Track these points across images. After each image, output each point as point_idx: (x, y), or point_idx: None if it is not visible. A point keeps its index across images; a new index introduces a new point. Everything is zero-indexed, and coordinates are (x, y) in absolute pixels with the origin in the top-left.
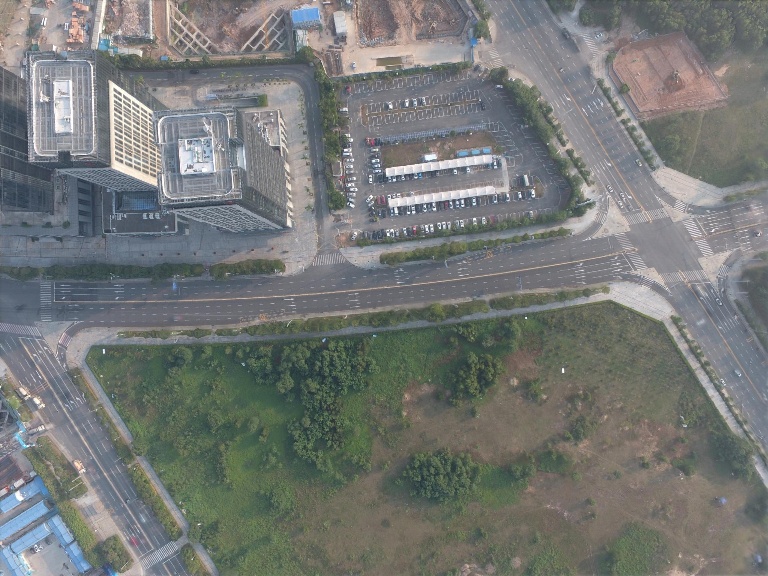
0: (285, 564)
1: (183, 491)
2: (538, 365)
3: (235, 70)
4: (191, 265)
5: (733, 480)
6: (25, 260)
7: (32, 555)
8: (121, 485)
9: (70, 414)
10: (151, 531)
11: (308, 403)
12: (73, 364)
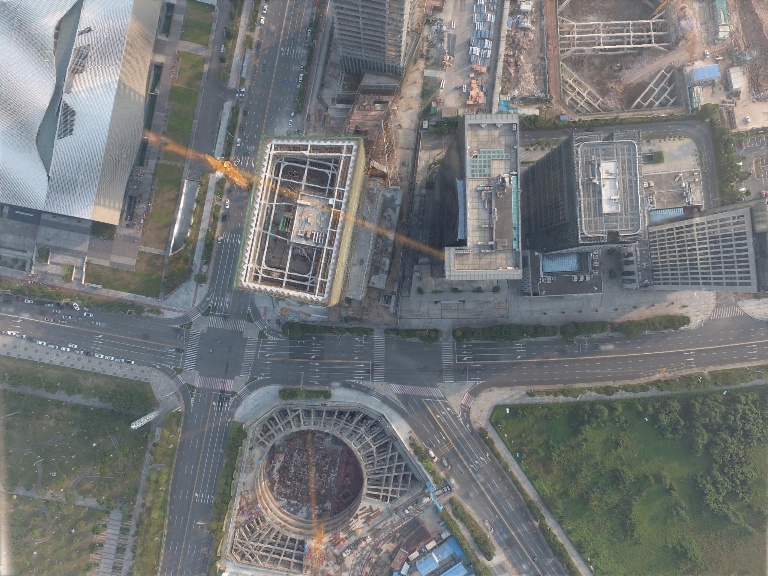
0: None
1: (590, 547)
2: None
3: (630, 127)
4: (600, 323)
5: None
6: (426, 322)
7: None
8: (528, 543)
9: (476, 474)
10: None
11: (718, 456)
12: (477, 424)
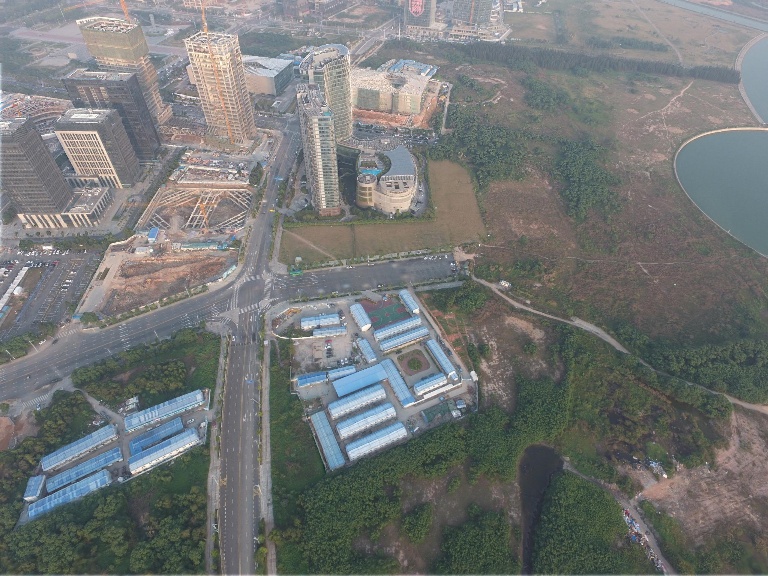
0: None
1: None
2: None
3: None
4: None
5: None
6: None
7: None
8: None
9: None
10: None
11: None
12: None
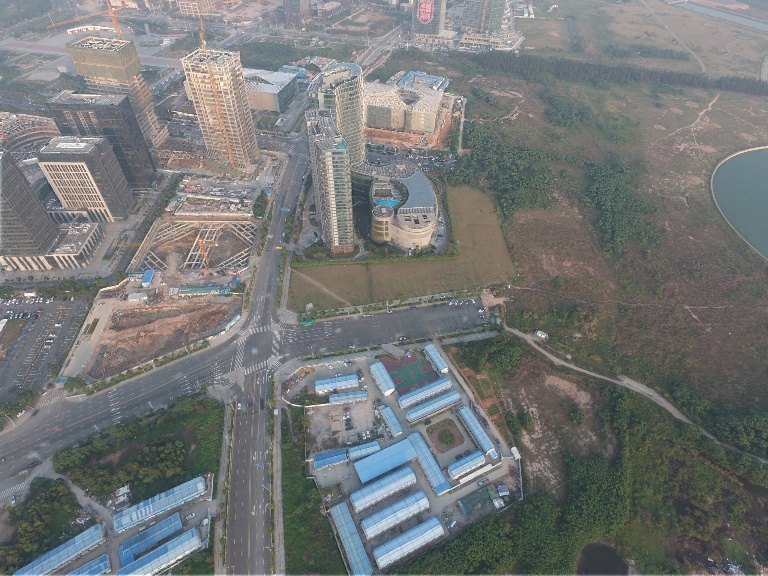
0: None
1: None
2: None
3: None
4: None
5: None
6: None
7: None
8: None
9: None
10: None
11: None
12: None
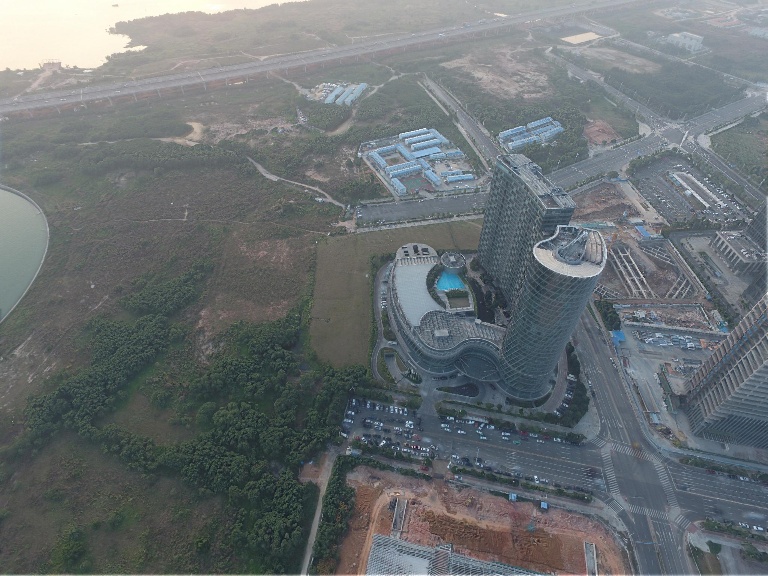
0: None
1: None
2: (763, 165)
3: None
4: None
5: (761, 123)
6: None
7: None
8: None
9: None
10: None
11: None
12: None
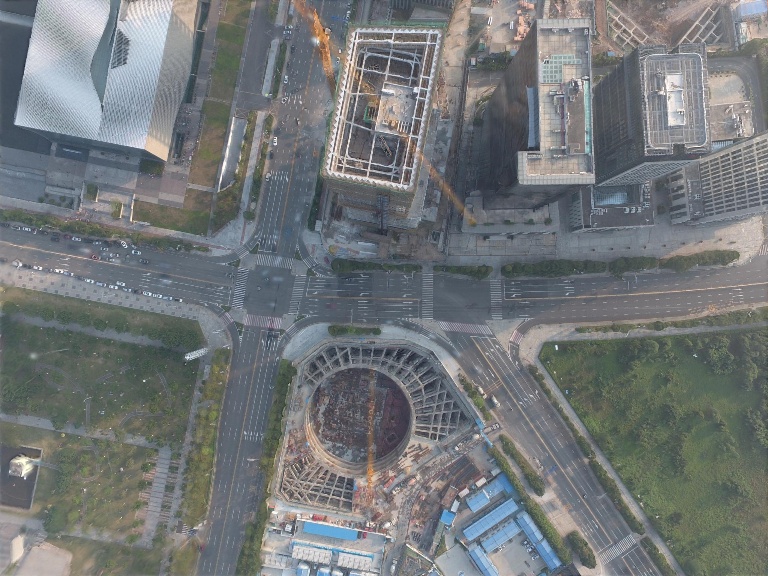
0: (744, 553)
1: (640, 484)
2: None
3: None
4: (649, 258)
5: None
6: (475, 259)
7: (493, 554)
8: (578, 481)
9: (525, 411)
10: (609, 526)
11: (767, 392)
12: (526, 361)
